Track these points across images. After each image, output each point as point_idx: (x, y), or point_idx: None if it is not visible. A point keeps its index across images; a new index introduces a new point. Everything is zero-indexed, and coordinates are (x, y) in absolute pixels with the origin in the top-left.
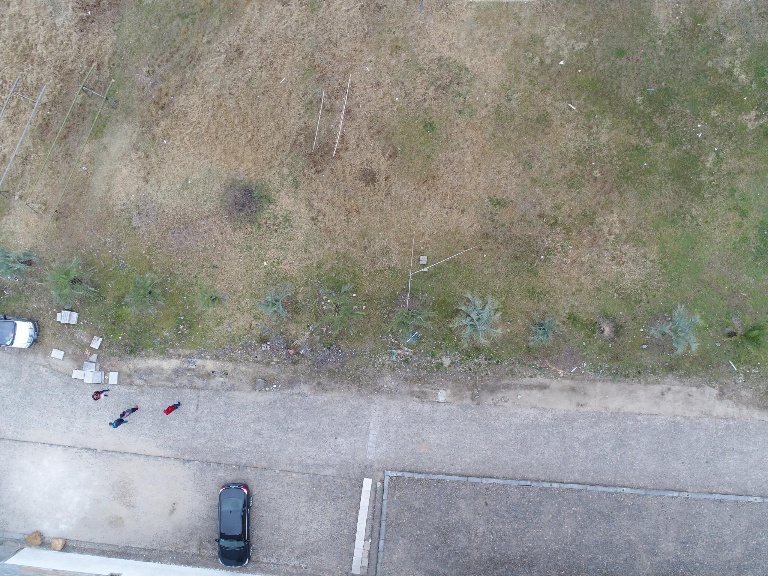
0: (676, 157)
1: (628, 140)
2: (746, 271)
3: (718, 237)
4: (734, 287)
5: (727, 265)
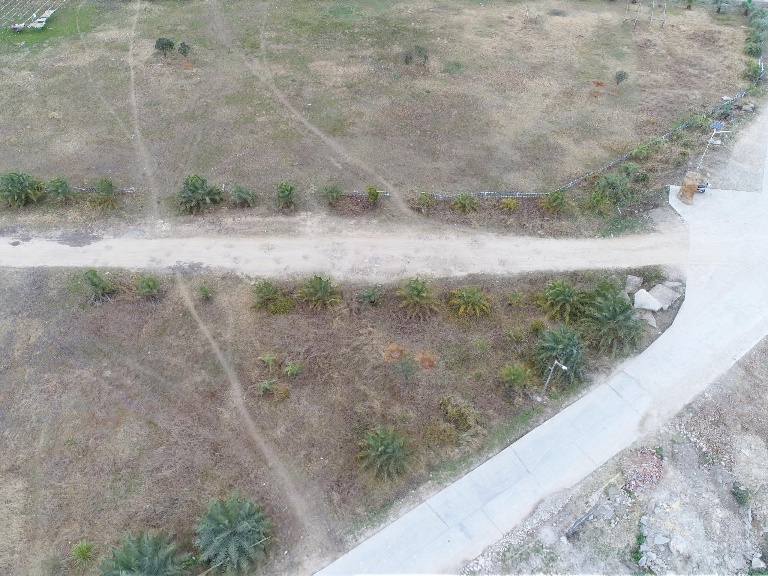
0: (387, 23)
1: (407, 25)
2: (356, 6)
3: (368, 11)
4: (361, 4)
5: (364, 7)
